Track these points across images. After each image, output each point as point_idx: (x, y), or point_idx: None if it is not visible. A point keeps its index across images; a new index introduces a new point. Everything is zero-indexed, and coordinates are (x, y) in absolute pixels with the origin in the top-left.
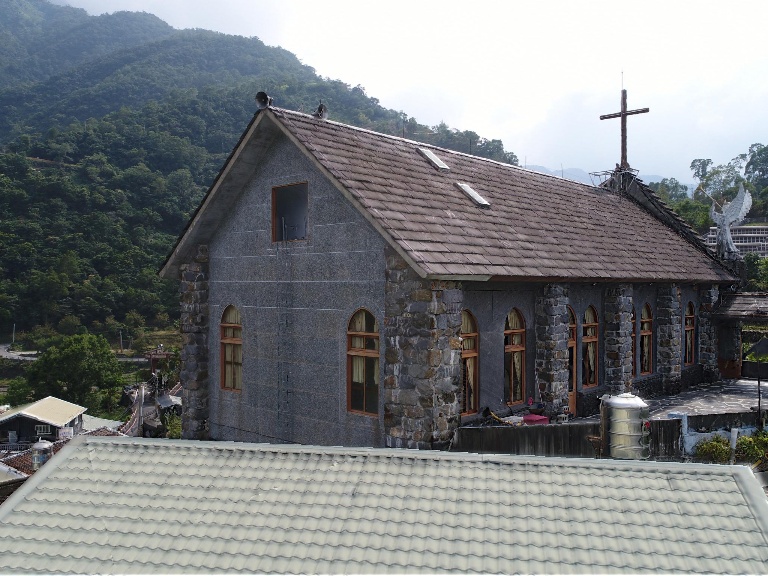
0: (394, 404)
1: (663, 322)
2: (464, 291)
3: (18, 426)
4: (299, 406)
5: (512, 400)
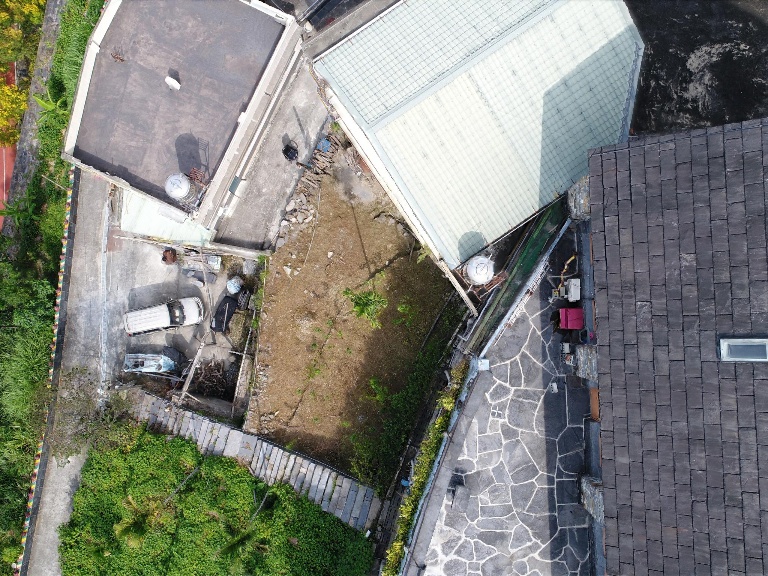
0: None
1: None
2: None
3: None
4: None
5: None
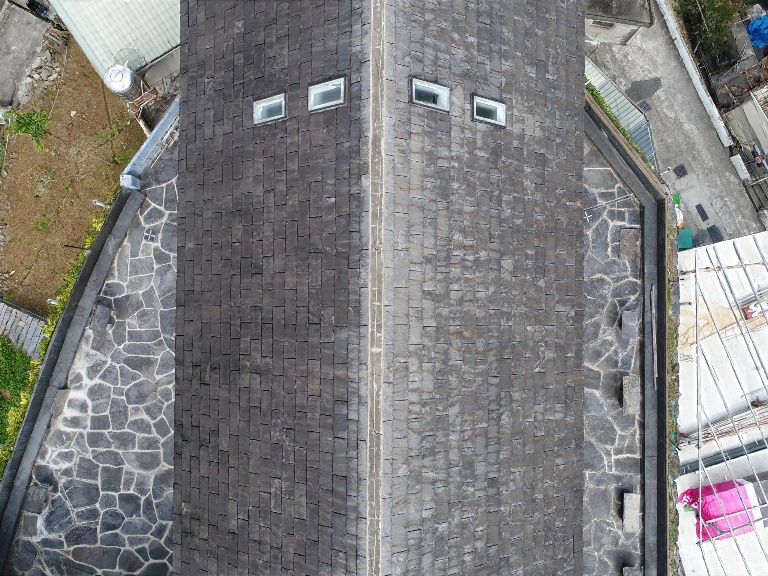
0: None
1: None
2: None
3: None
4: None
5: None
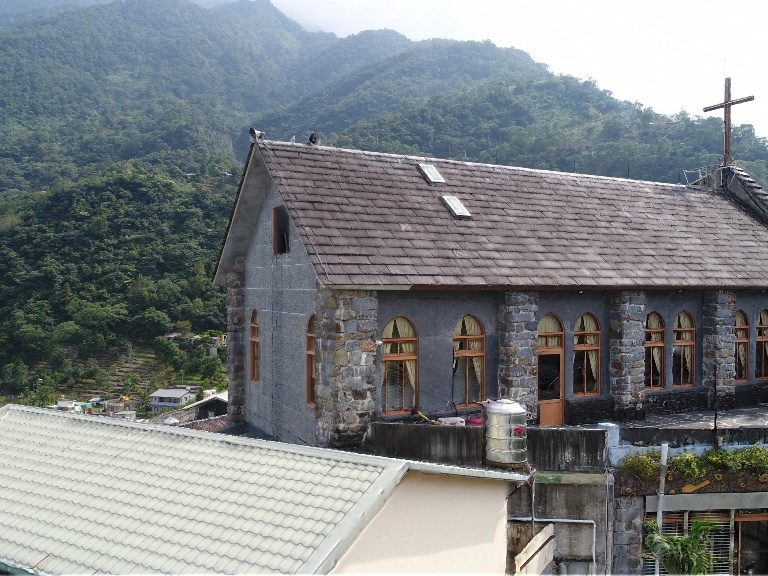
0: (320, 398)
1: (708, 332)
2: (398, 299)
3: (216, 408)
4: (285, 397)
5: (467, 402)
